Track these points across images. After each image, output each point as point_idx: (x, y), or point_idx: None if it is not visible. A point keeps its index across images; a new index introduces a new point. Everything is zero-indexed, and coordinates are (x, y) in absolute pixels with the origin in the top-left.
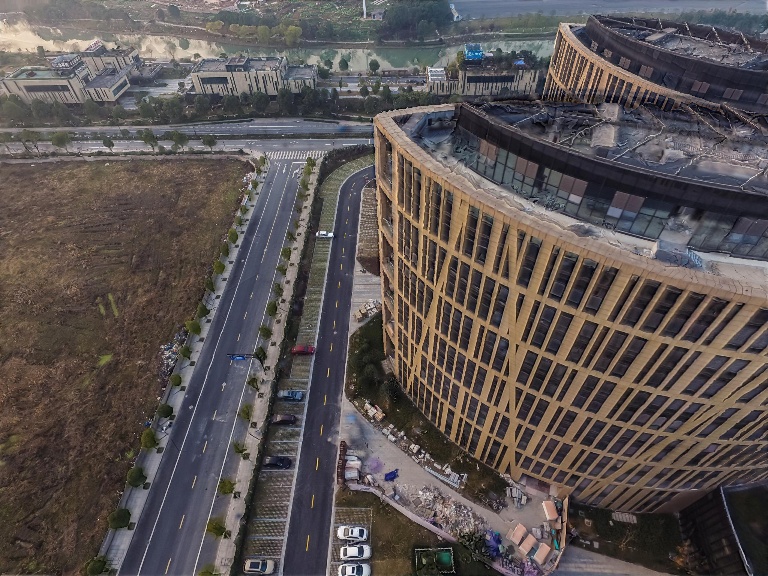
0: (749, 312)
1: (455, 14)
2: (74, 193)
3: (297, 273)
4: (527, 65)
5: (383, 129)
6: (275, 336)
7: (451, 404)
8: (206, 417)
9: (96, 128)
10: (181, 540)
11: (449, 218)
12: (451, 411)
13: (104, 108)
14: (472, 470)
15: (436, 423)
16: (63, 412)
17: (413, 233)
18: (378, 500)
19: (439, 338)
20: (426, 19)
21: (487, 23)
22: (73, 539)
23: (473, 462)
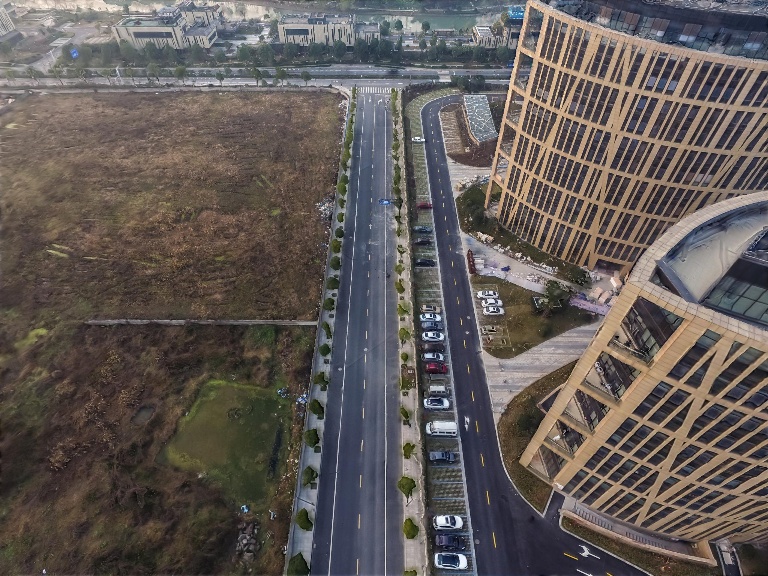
0: (756, 75)
1: None
2: (202, 112)
3: (404, 162)
4: None
5: (537, 5)
6: None
7: (551, 213)
8: (364, 242)
9: (198, 69)
10: (371, 301)
11: (584, 52)
12: (549, 221)
13: (203, 53)
14: (561, 264)
15: (532, 240)
16: (259, 239)
17: (550, 74)
18: (500, 280)
19: (554, 154)
20: None
21: None
22: (297, 300)
23: (560, 261)
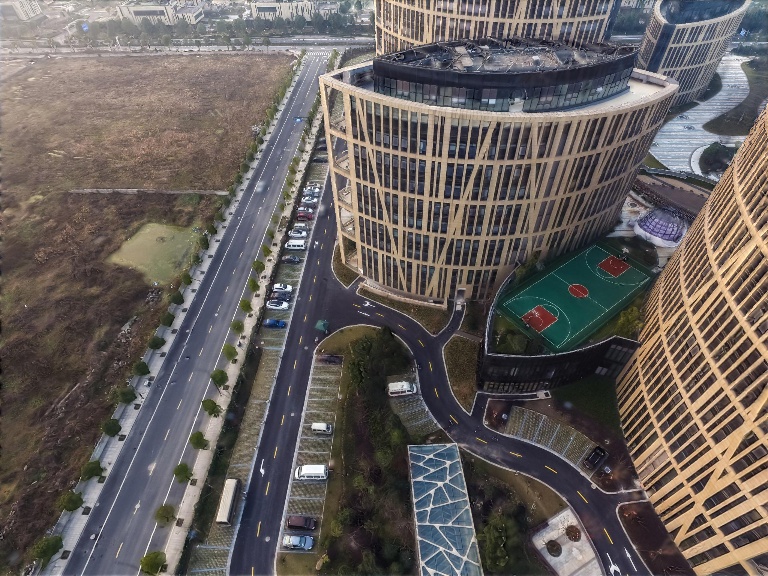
0: None
1: None
2: (180, 69)
3: None
4: None
5: None
6: (316, 124)
7: None
8: (280, 149)
9: None
10: (273, 182)
11: None
12: None
13: (189, 27)
14: None
15: None
16: (202, 147)
17: (389, 8)
18: None
19: None
20: None
21: None
22: (220, 181)
23: None
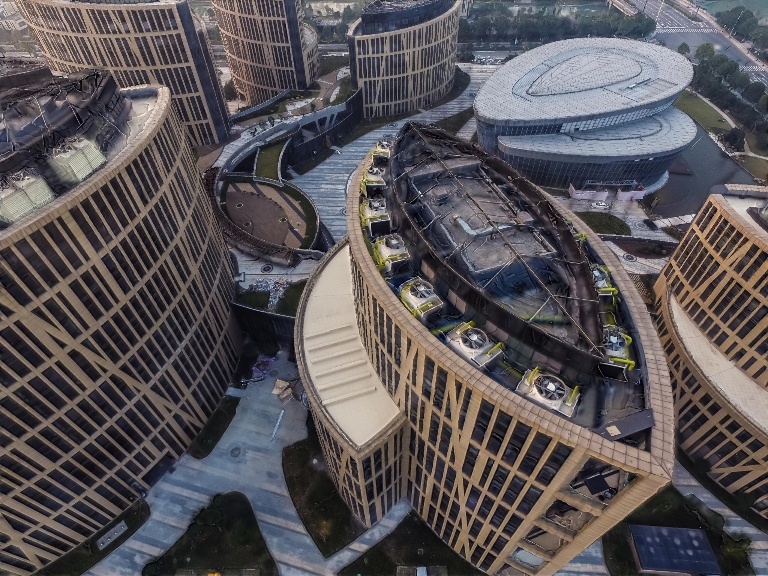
0: None
1: None
2: None
3: None
4: None
5: None
6: None
7: None
8: None
9: None
10: None
11: None
12: None
13: (10, 34)
14: None
15: None
16: None
17: None
18: None
19: None
20: None
21: None
22: None
23: None
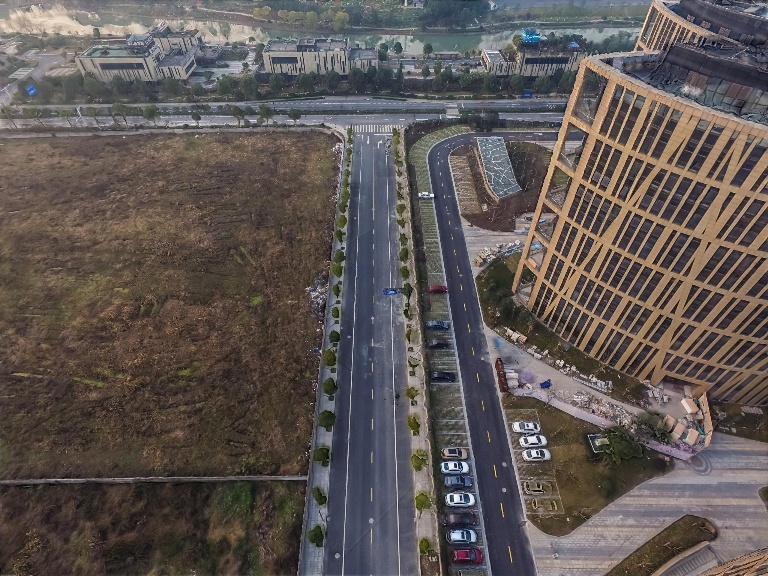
0: None
1: (492, 3)
2: (174, 161)
3: (411, 227)
4: (580, 48)
5: (598, 68)
6: None
7: (605, 317)
8: (366, 344)
9: (173, 104)
10: (376, 438)
11: (668, 135)
12: (601, 325)
13: (179, 86)
14: (615, 378)
15: (576, 342)
16: (234, 342)
17: (613, 157)
18: (540, 403)
19: (613, 253)
20: (467, 7)
21: (522, 12)
22: (281, 439)
23: (614, 372)
